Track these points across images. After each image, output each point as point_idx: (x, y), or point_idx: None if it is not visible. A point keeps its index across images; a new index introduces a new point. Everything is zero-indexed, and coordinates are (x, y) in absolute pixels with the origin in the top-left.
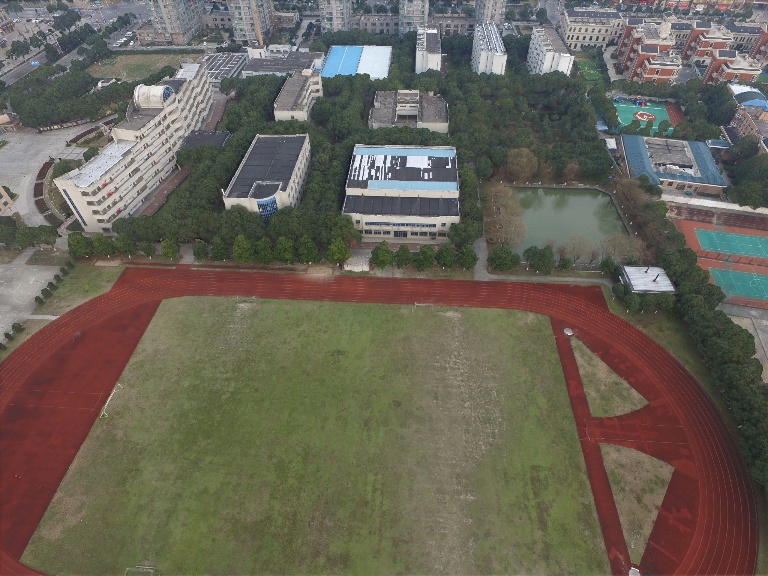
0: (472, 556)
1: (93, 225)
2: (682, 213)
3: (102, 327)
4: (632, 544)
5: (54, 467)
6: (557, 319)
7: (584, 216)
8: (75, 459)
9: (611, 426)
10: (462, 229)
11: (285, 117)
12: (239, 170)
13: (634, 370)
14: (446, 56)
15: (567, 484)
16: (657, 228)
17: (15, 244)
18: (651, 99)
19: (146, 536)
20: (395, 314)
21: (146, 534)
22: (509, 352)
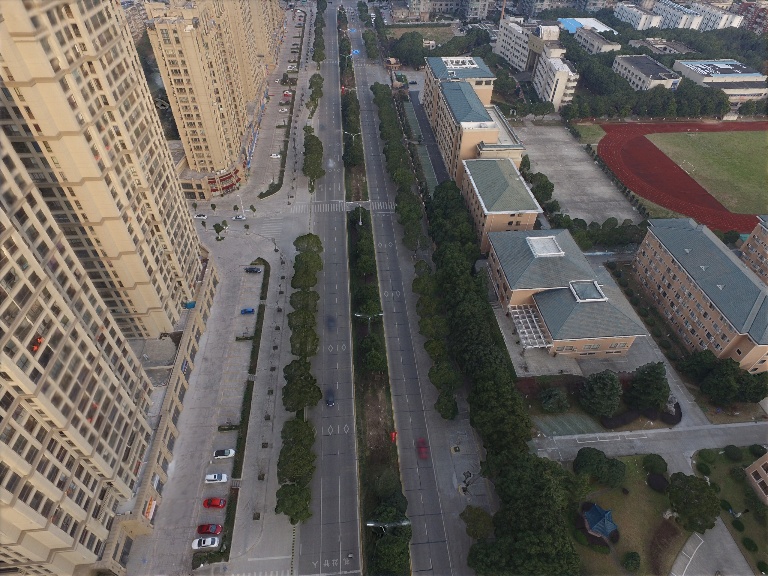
0: None
1: (555, 106)
2: None
3: (630, 146)
4: None
5: (696, 188)
6: None
7: None
8: None
9: None
10: None
11: (608, 50)
12: None
13: None
14: None
15: None
16: None
17: None
18: None
19: None
20: None
21: None
22: None
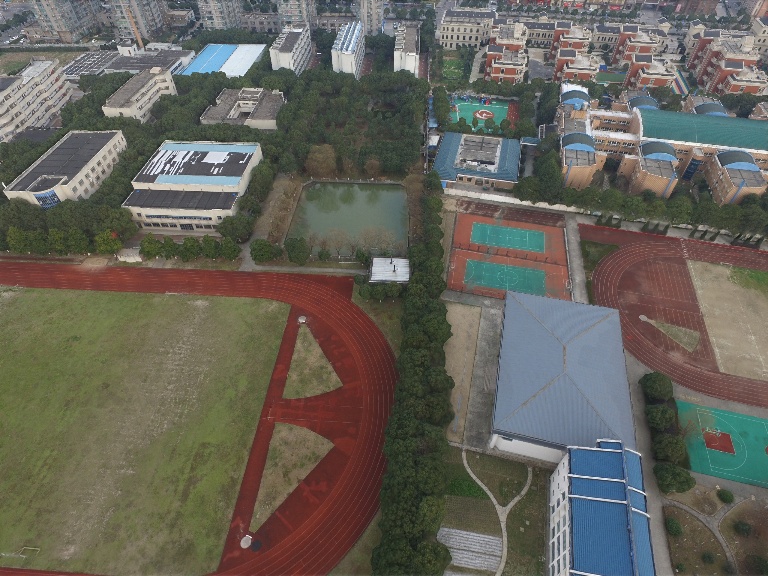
0: (104, 524)
1: None
2: (470, 208)
3: None
4: (258, 514)
5: None
6: (297, 307)
7: (393, 211)
8: None
9: (295, 407)
10: (229, 222)
11: (114, 114)
12: (35, 164)
13: (345, 355)
14: (321, 55)
15: (226, 460)
16: (423, 221)
17: None
18: (498, 98)
19: None
20: (146, 302)
21: None
22: (236, 338)
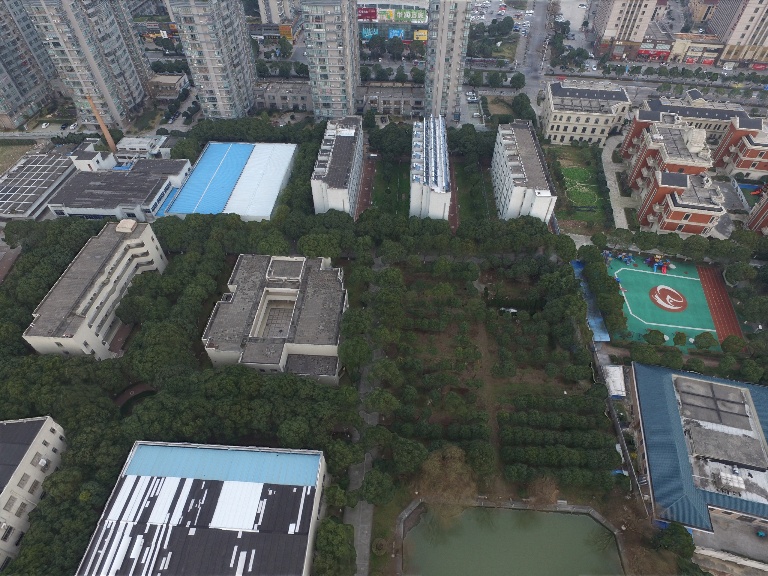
0: None
1: None
2: None
3: None
4: None
5: None
6: None
7: (568, 550)
8: None
9: None
10: None
11: (46, 343)
12: None
13: None
14: (376, 157)
15: None
16: None
17: None
18: (676, 256)
19: None
20: None
21: None
22: None
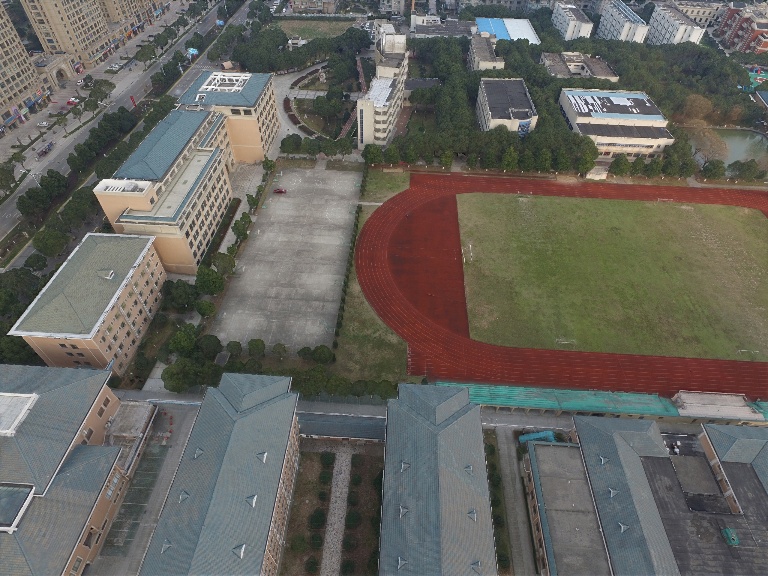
0: None
1: (368, 143)
2: None
3: (422, 210)
4: None
5: (454, 290)
6: (767, 211)
7: (738, 153)
8: (465, 286)
9: None
10: (680, 147)
11: (488, 67)
12: None
13: None
14: None
15: None
16: None
17: (317, 153)
18: (763, 68)
19: (550, 327)
20: (643, 206)
21: (549, 326)
22: (742, 230)
